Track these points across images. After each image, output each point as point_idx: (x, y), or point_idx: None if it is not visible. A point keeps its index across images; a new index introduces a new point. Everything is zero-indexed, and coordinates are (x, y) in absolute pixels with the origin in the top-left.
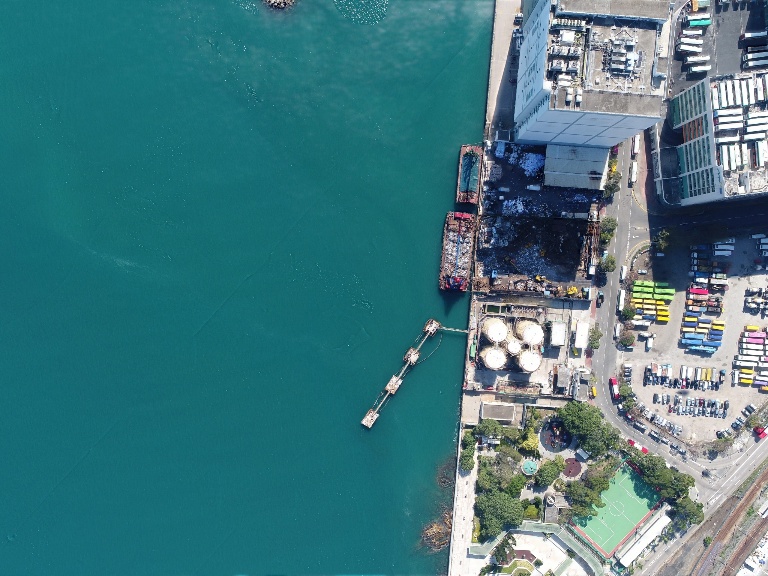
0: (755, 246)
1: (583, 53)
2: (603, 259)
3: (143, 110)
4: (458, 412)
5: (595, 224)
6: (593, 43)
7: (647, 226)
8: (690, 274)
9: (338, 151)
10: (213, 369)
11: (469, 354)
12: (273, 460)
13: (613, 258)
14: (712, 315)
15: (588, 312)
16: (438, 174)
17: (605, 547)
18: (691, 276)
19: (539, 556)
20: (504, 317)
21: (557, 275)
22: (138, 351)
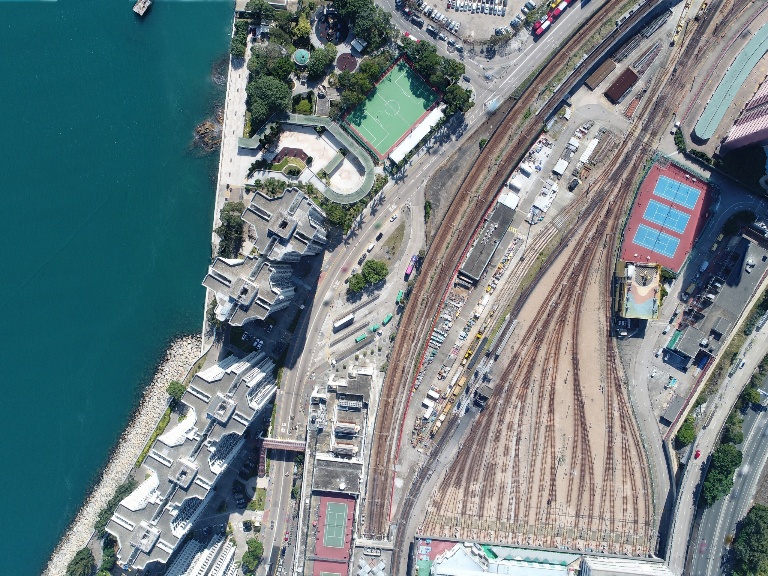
0: None
1: None
2: None
3: None
4: (234, 4)
5: None
6: None
7: None
8: None
9: None
10: None
11: None
12: (23, 13)
13: None
14: None
15: None
16: None
17: (379, 148)
18: None
19: (311, 155)
20: None
21: None
22: None
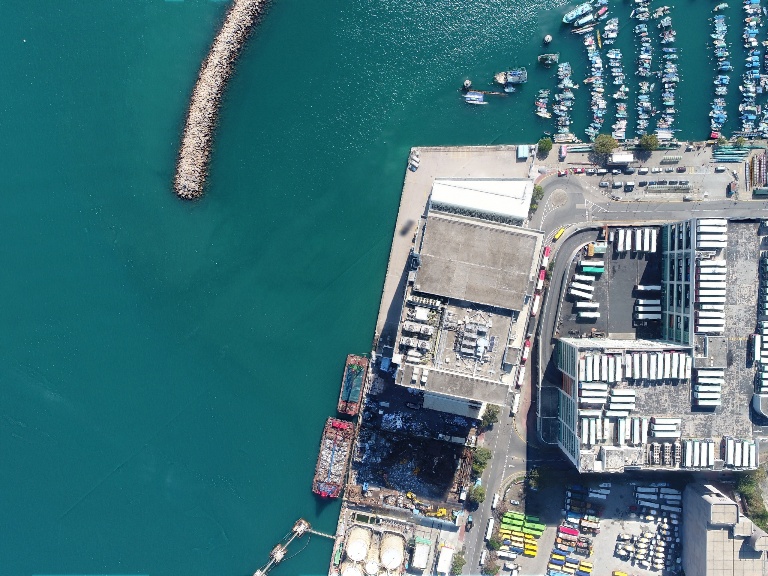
0: (632, 492)
1: (437, 330)
2: (473, 489)
3: (35, 296)
4: None
5: (468, 454)
6: (446, 323)
7: (525, 457)
8: (562, 512)
9: (228, 344)
10: (74, 553)
11: (334, 559)
12: None
13: (482, 491)
14: (581, 555)
15: (456, 534)
16: (323, 378)
17: None
18: (563, 514)
19: None
20: (371, 529)
21: (429, 494)
22: (5, 526)
